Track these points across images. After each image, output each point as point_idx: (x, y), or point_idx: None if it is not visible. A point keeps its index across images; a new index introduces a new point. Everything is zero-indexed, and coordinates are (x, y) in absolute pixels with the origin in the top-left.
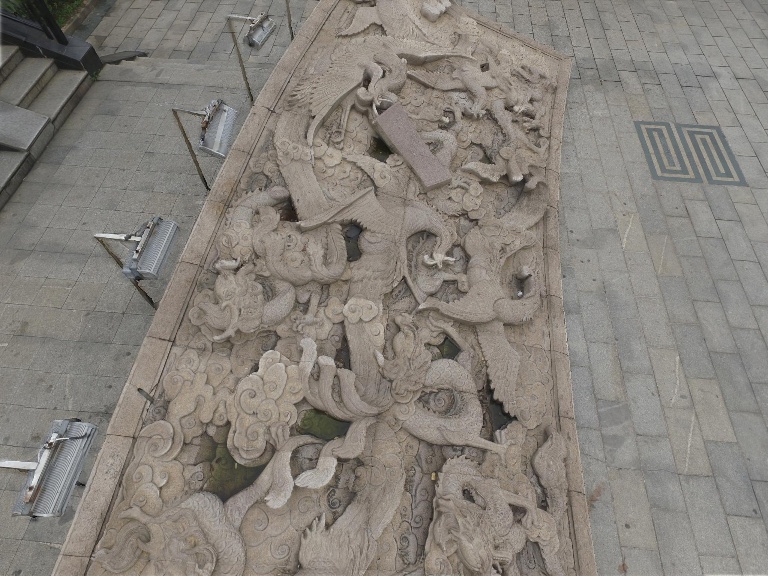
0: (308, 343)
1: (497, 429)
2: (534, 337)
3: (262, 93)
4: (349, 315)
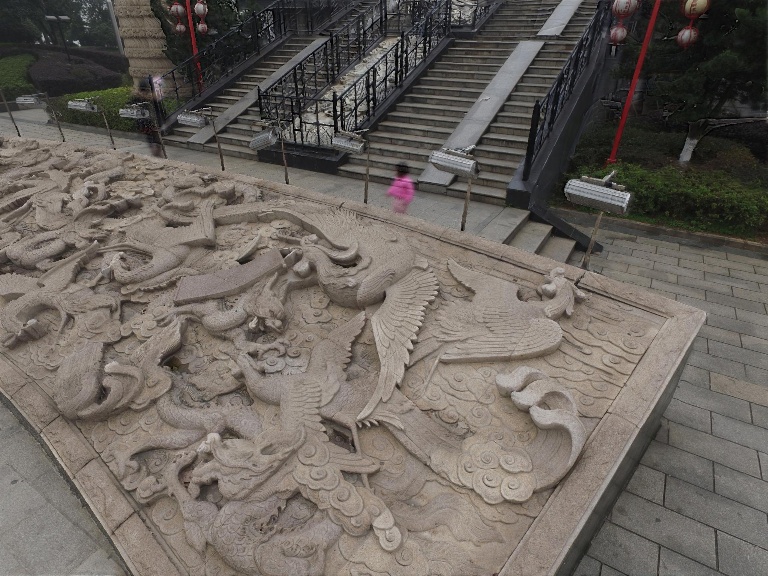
0: None
1: None
2: None
3: None
4: None
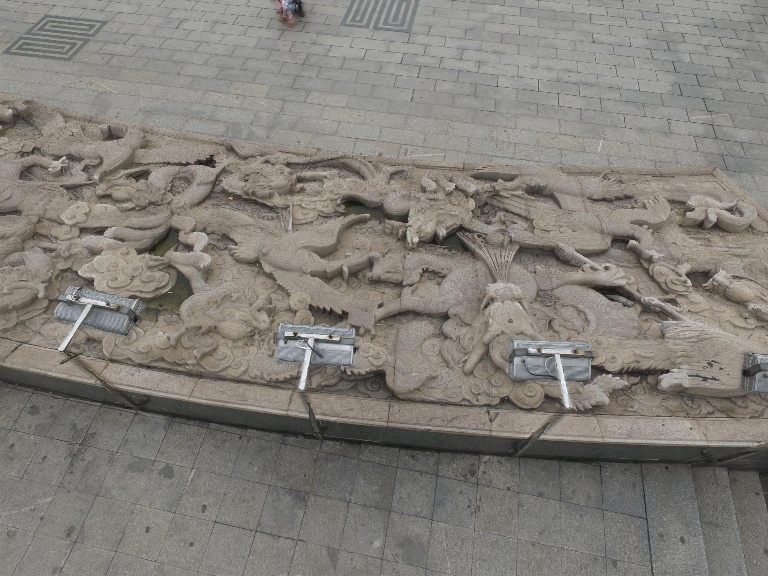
0: (86, 240)
1: None
2: (160, 142)
3: None
4: (76, 220)
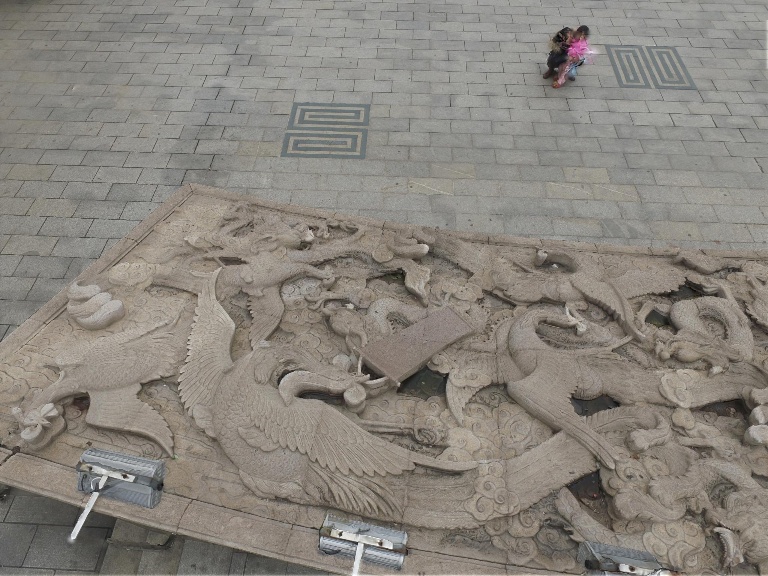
0: (757, 434)
1: (698, 292)
2: None
3: (363, 571)
4: (689, 401)
